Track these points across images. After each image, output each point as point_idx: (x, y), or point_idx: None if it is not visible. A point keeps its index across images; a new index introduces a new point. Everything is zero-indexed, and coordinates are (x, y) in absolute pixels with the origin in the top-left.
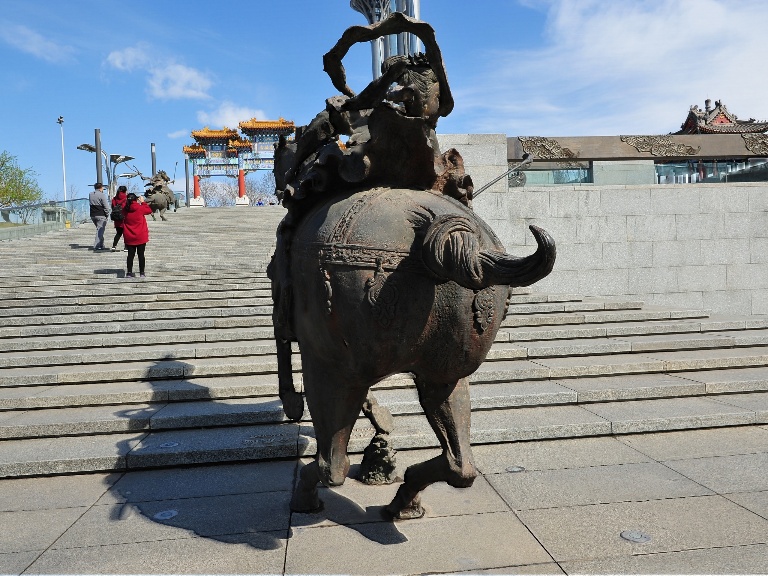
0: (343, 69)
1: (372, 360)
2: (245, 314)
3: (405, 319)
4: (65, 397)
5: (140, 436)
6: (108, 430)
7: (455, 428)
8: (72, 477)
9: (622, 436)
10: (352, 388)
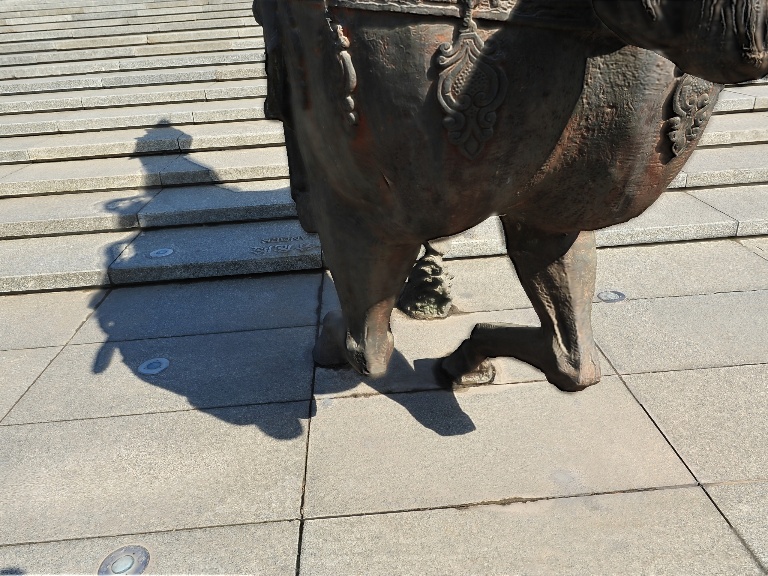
0: None
1: (439, 215)
2: (253, 60)
3: (515, 139)
4: (35, 183)
5: (128, 237)
6: (89, 229)
7: (571, 306)
8: (47, 295)
9: (748, 239)
10: (398, 245)
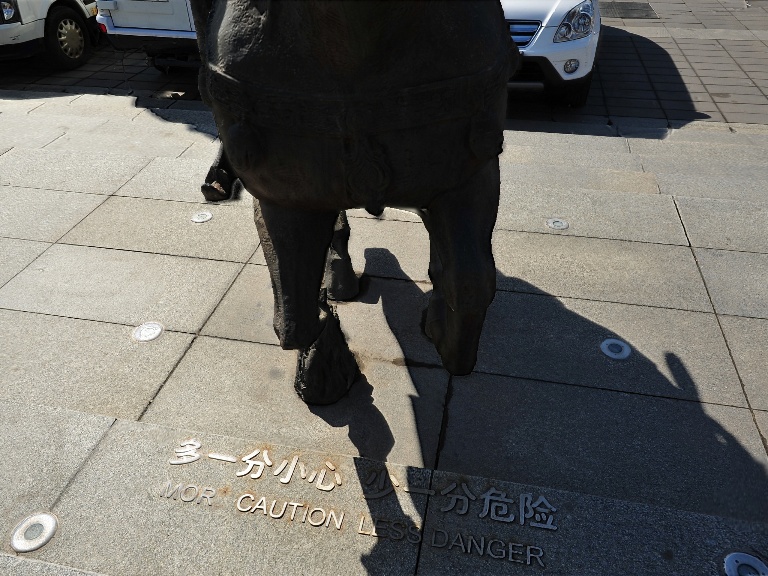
0: None
1: None
2: None
3: None
4: None
5: None
6: None
7: None
8: None
9: None
10: None
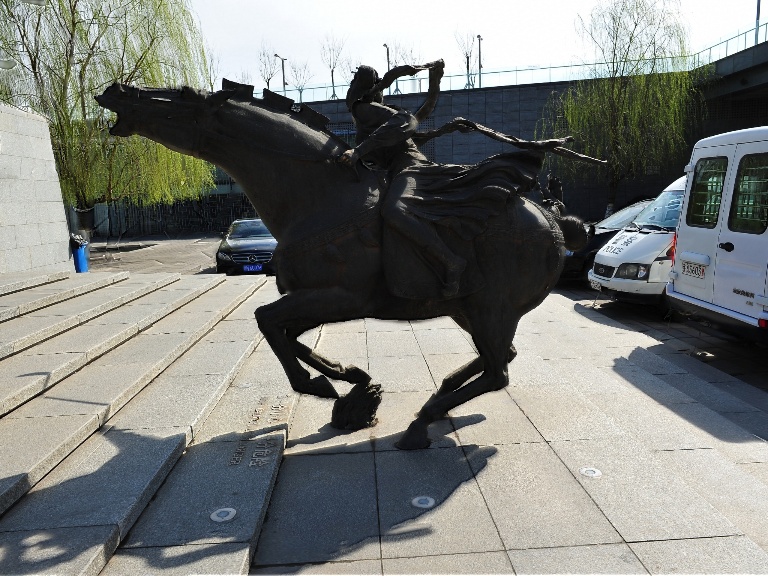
0: None
1: None
2: None
3: None
4: None
5: (138, 553)
6: None
7: None
8: None
9: None
10: None
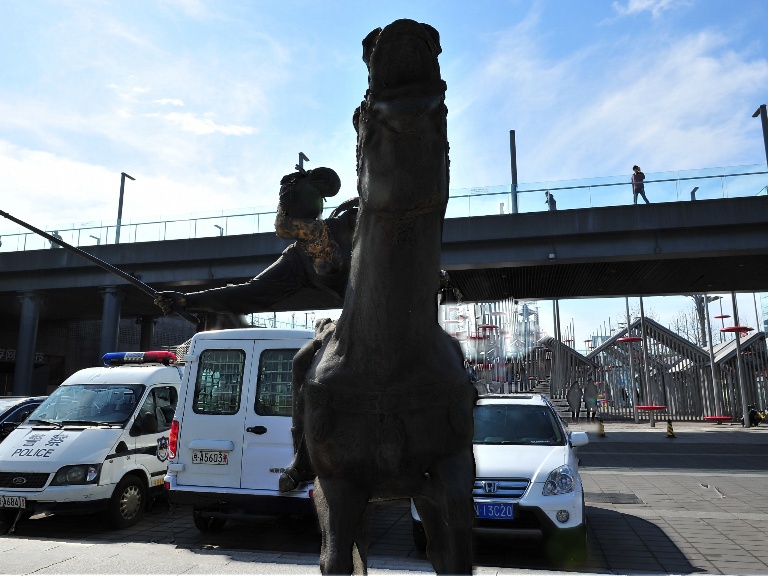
0: None
1: None
2: None
3: None
4: None
5: None
6: None
7: None
8: None
9: None
10: None
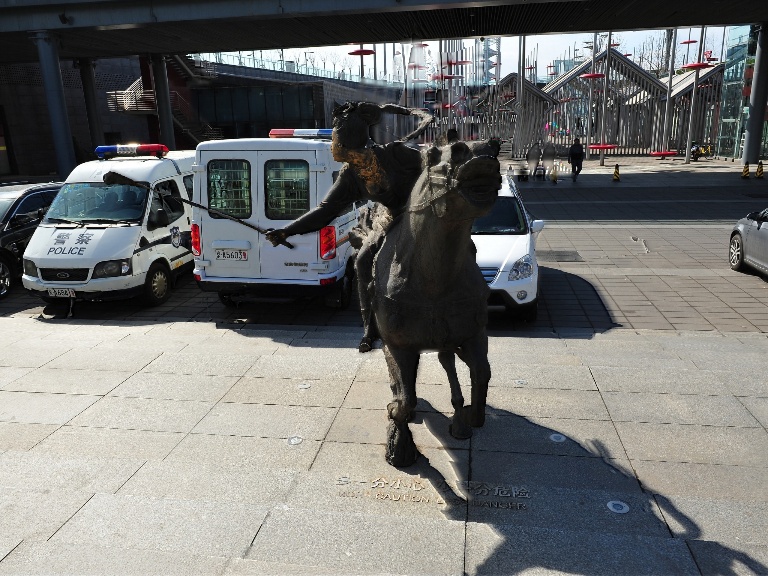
0: (420, 123)
1: None
2: None
3: None
4: None
5: None
6: None
7: None
8: None
9: None
10: None
